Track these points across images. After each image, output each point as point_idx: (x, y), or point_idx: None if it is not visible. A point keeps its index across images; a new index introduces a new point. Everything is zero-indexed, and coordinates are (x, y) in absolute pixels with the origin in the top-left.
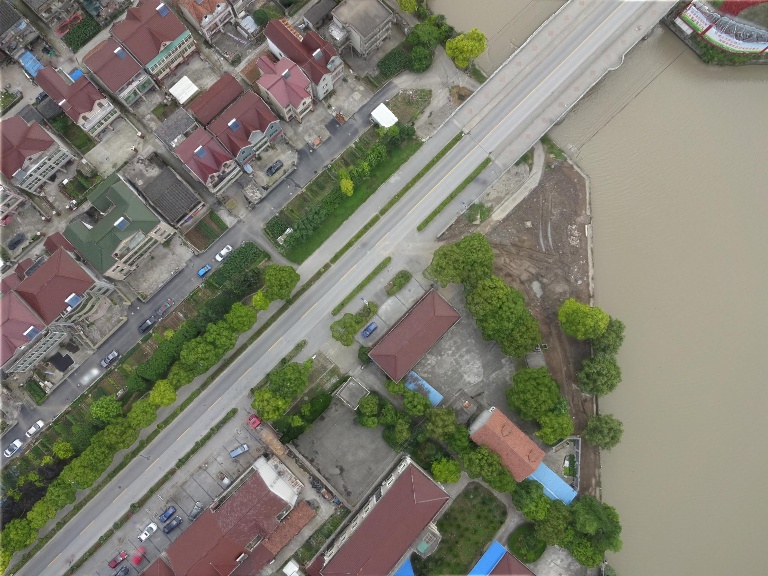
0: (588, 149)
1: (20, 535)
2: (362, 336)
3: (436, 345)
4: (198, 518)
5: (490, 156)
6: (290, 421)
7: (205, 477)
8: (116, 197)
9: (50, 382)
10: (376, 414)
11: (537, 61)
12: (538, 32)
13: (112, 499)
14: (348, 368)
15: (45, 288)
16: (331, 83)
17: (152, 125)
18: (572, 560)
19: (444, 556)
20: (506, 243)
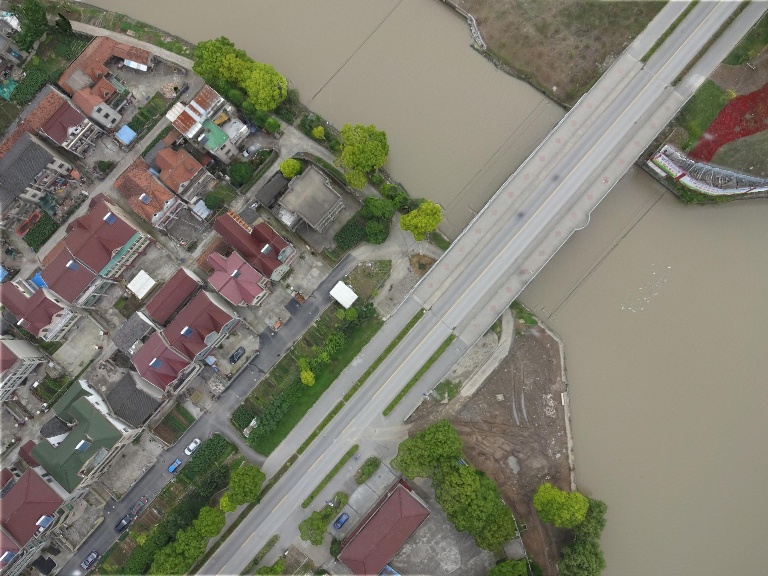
0: (559, 312)
1: None
2: (334, 527)
3: None
4: None
5: (454, 332)
6: None
7: None
8: (78, 415)
9: None
10: None
11: (498, 227)
12: (497, 195)
13: None
14: (322, 561)
15: (15, 515)
16: (286, 266)
17: (115, 319)
18: None
19: None
20: (477, 420)
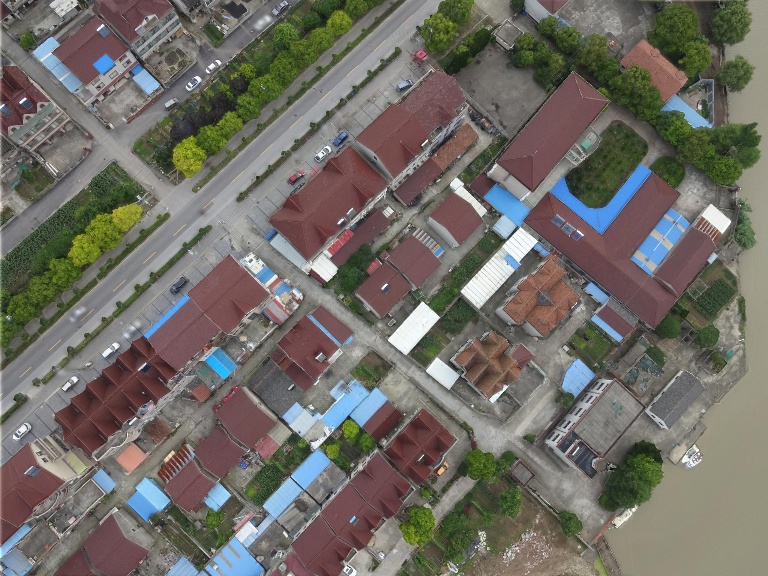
0: None
1: (215, 135)
2: None
3: (579, 2)
4: (384, 112)
5: None
6: (455, 51)
7: (373, 109)
8: None
9: (226, 26)
10: (532, 48)
11: None
12: None
13: (289, 125)
14: (500, 19)
15: None
16: None
17: None
18: (707, 189)
19: (593, 182)
20: None
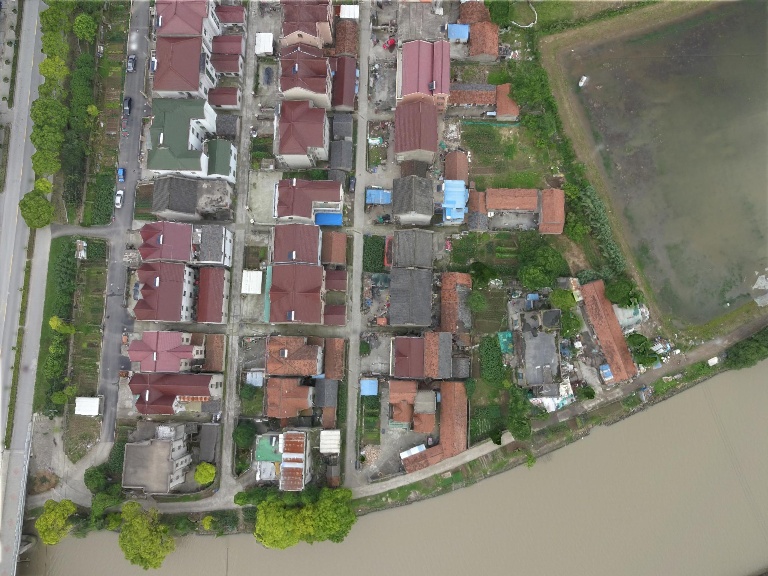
0: None
1: None
2: None
3: None
4: None
5: None
6: None
7: None
8: (191, 155)
9: None
10: None
11: None
12: None
13: None
14: None
15: None
16: None
17: (258, 238)
18: None
19: None
20: None
